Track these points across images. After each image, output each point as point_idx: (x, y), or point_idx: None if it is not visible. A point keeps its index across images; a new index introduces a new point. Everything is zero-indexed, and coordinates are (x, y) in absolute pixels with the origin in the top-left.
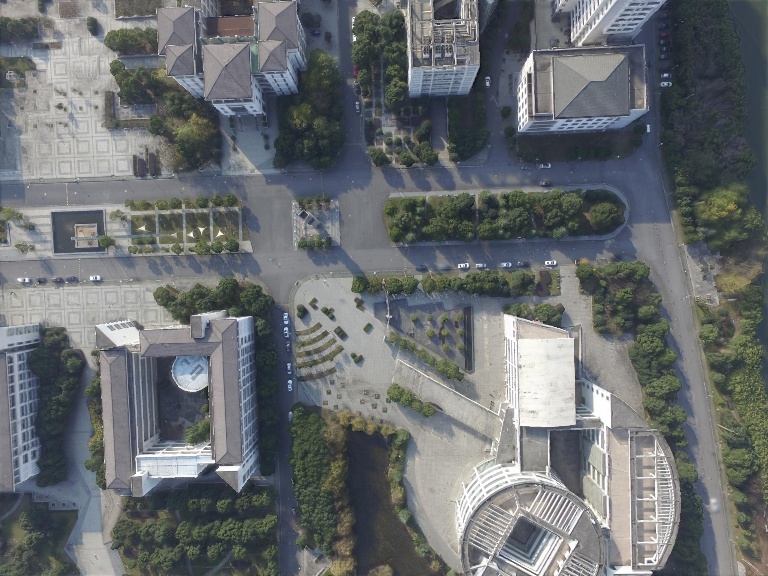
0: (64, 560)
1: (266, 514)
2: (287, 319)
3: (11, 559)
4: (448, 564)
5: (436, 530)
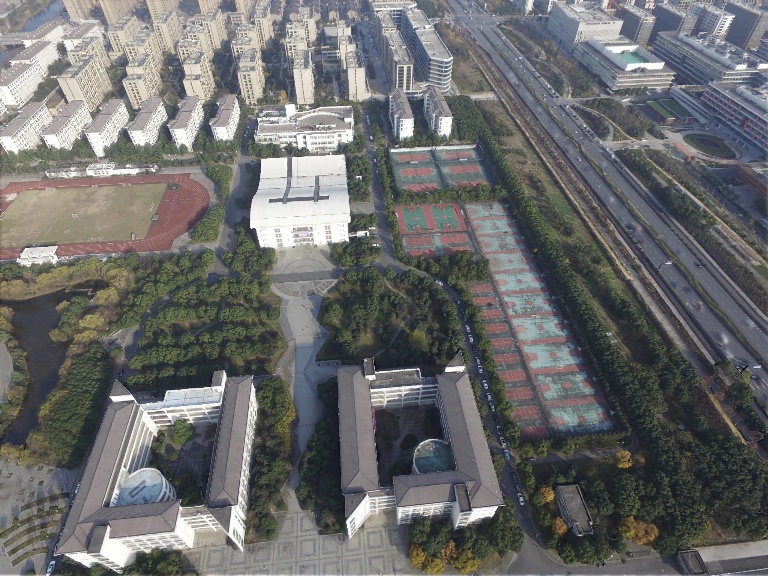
0: (329, 326)
1: (146, 370)
2: (49, 567)
3: (373, 324)
4: (5, 346)
5: (0, 369)
